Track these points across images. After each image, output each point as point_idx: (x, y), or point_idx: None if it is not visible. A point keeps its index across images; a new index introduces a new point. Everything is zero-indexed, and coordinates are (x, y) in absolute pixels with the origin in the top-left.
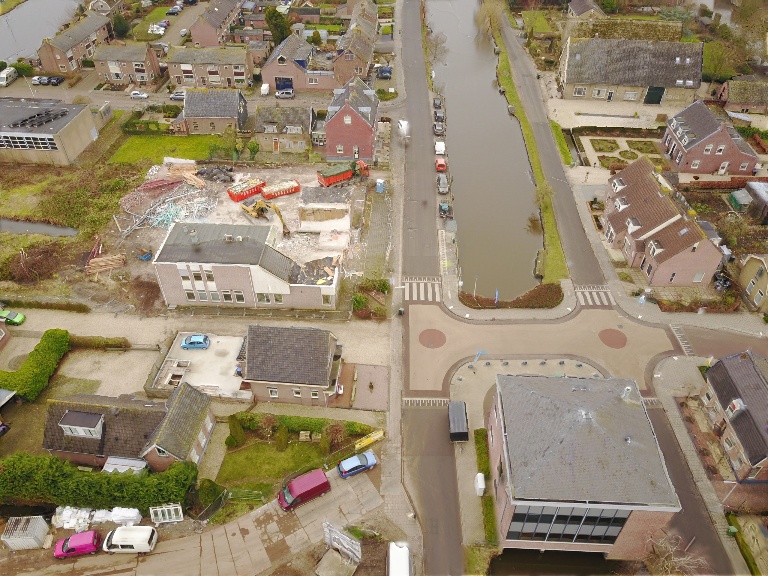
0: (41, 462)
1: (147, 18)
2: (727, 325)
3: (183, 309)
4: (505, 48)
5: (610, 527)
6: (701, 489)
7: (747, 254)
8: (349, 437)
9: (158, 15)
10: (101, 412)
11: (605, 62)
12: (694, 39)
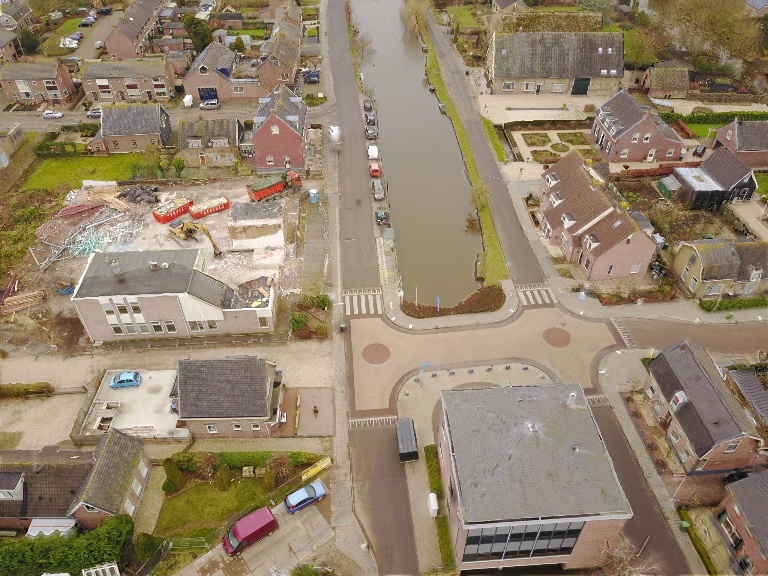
0: None
1: (58, 31)
2: (665, 314)
3: (110, 345)
4: (433, 45)
5: (565, 539)
6: (652, 485)
7: (679, 241)
8: (295, 468)
9: (70, 27)
10: (20, 471)
11: (531, 56)
12: (615, 28)
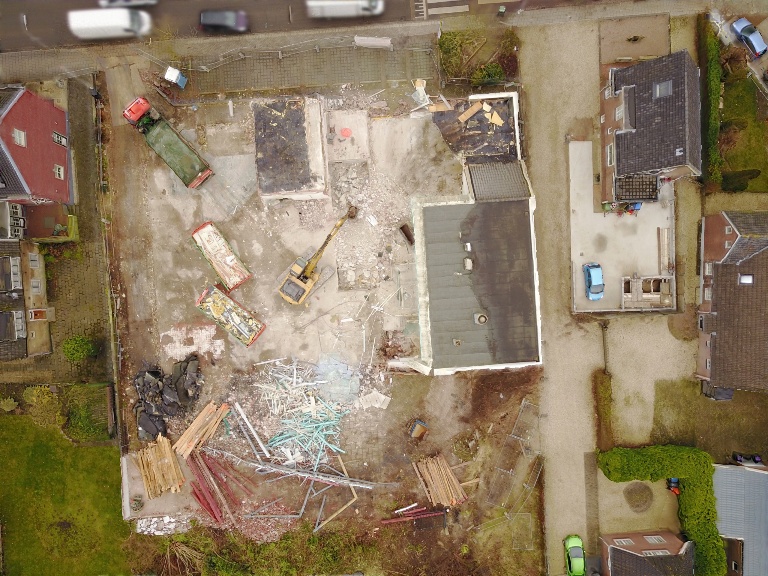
0: None
1: None
2: None
3: None
4: None
5: None
6: None
7: None
8: None
9: None
10: None
11: None
12: None
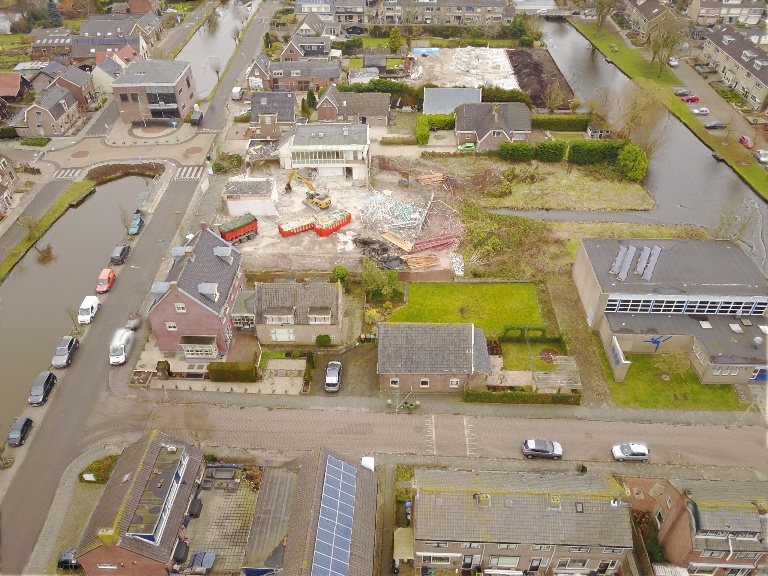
0: (376, 80)
1: None
2: None
3: None
4: None
5: None
6: None
7: None
8: None
9: None
10: None
11: None
12: None
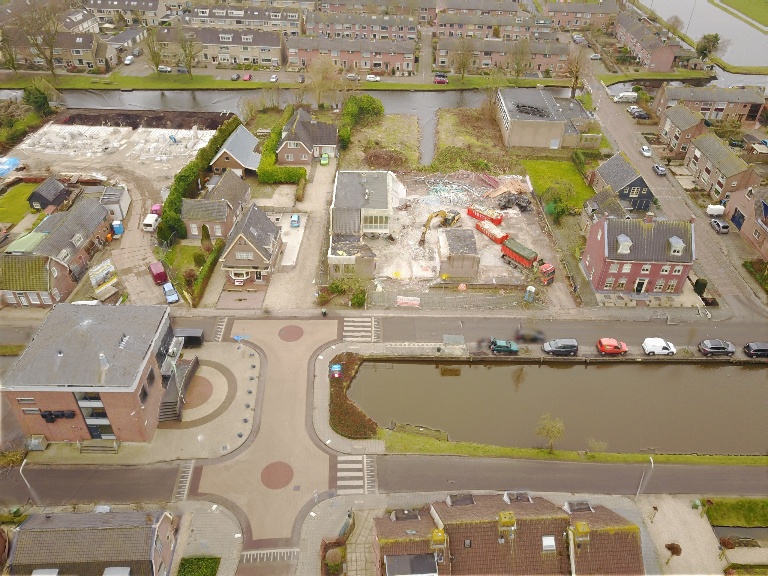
0: (184, 172)
1: None
2: None
3: None
4: None
5: None
6: None
7: None
8: None
9: None
10: None
11: None
12: None
